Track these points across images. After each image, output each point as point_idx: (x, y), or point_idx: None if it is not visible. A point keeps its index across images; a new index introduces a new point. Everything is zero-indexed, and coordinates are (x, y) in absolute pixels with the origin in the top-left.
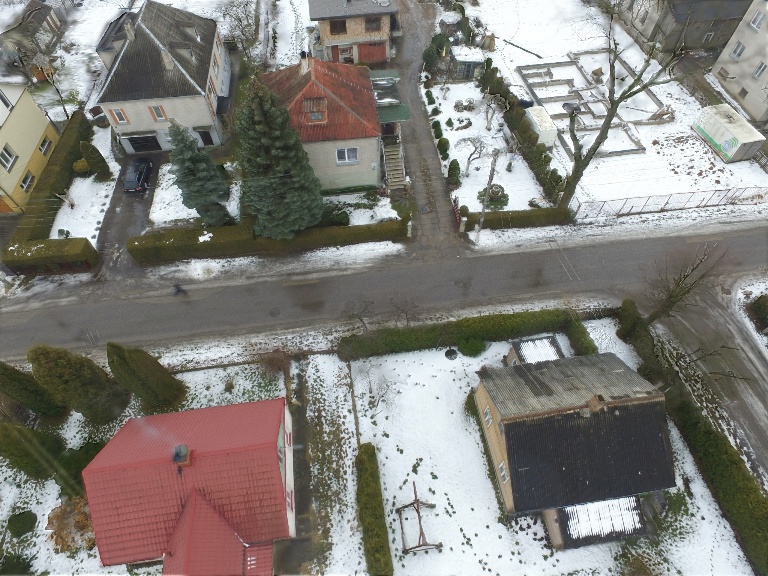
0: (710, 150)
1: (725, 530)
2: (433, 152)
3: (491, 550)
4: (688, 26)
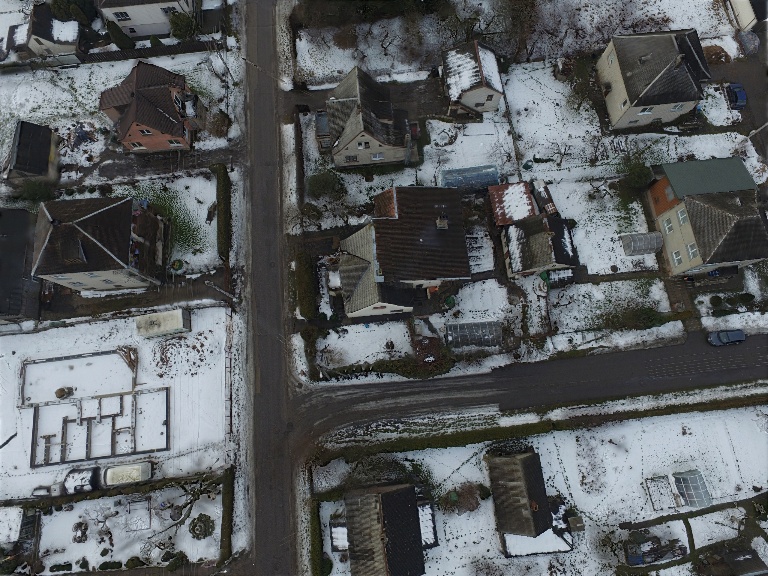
0: (178, 341)
1: (428, 451)
2: (138, 572)
3: (435, 573)
4: (23, 301)
